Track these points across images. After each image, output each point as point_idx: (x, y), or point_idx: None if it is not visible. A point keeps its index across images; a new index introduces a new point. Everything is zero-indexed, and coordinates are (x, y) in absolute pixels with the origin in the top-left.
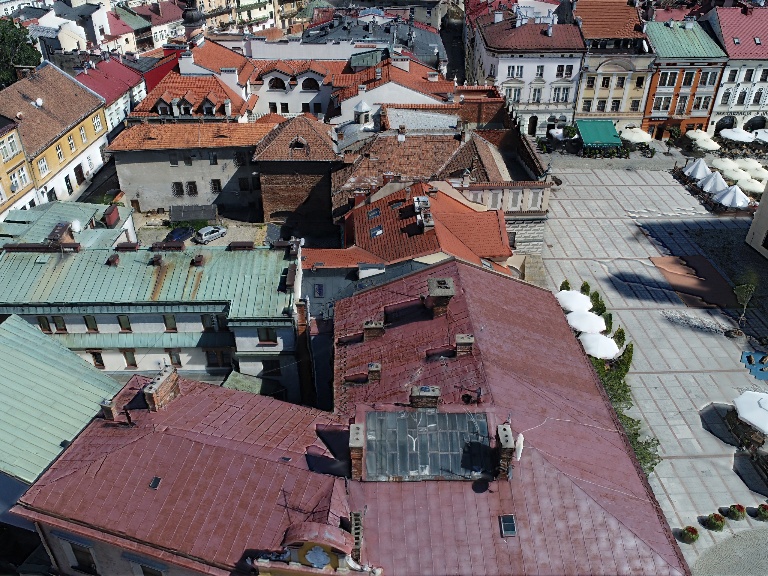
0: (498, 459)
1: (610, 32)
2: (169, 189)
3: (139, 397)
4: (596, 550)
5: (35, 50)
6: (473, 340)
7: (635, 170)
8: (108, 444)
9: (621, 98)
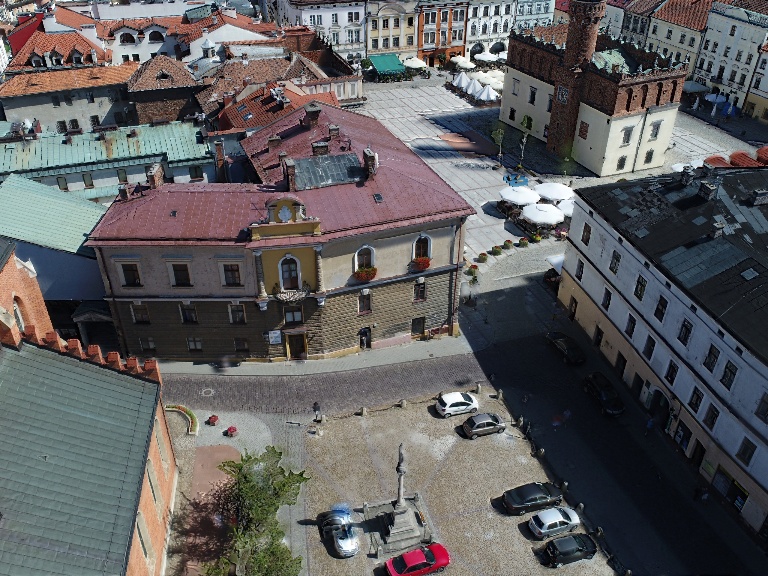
0: (367, 168)
1: None
2: (54, 128)
3: (138, 189)
4: (425, 202)
5: None
6: (339, 127)
7: (418, 87)
8: (133, 206)
9: (399, 36)
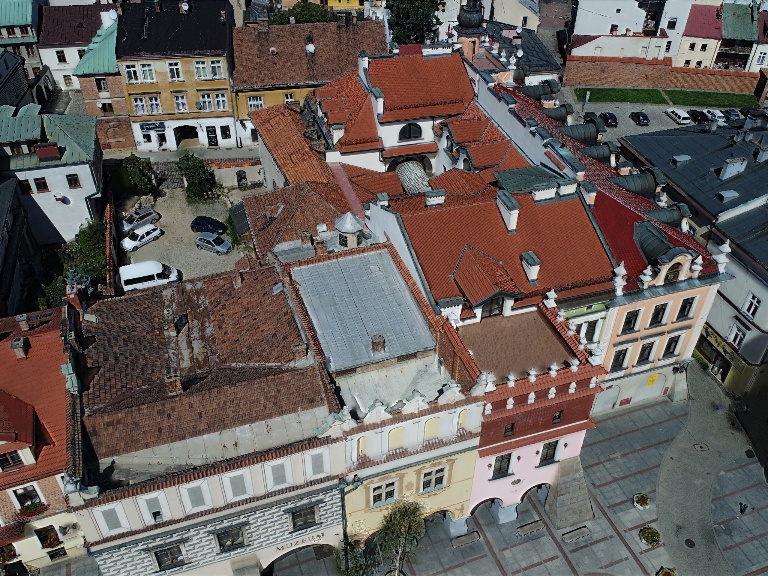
0: None
1: None
2: None
3: None
4: None
5: (427, 5)
6: None
7: None
8: None
9: None
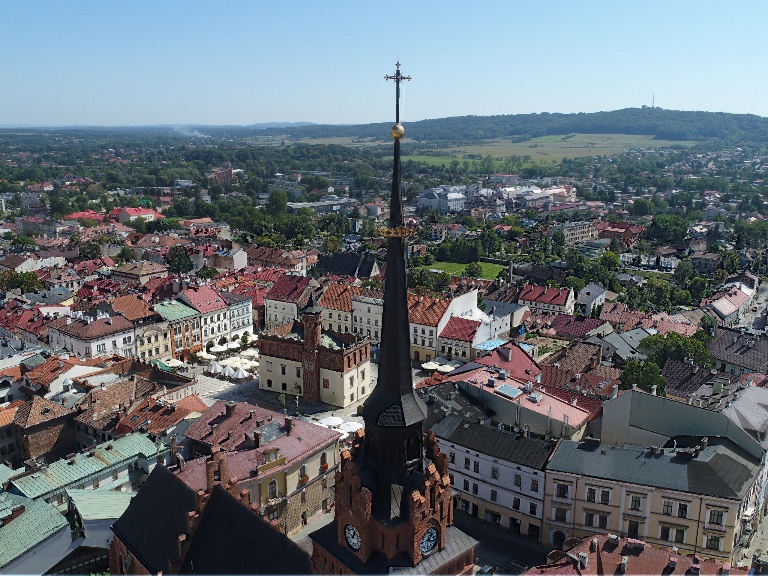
0: (289, 426)
1: (139, 315)
2: None
3: None
4: (321, 435)
5: None
6: (255, 410)
7: None
8: None
9: (159, 346)
